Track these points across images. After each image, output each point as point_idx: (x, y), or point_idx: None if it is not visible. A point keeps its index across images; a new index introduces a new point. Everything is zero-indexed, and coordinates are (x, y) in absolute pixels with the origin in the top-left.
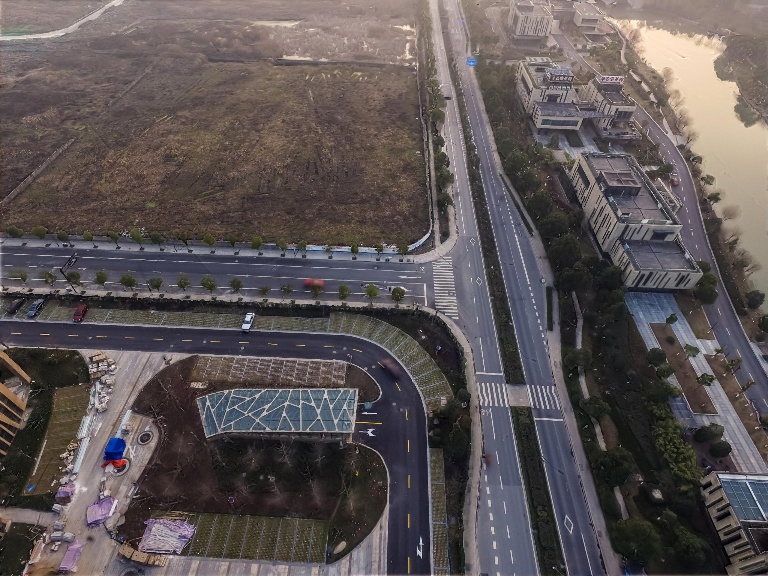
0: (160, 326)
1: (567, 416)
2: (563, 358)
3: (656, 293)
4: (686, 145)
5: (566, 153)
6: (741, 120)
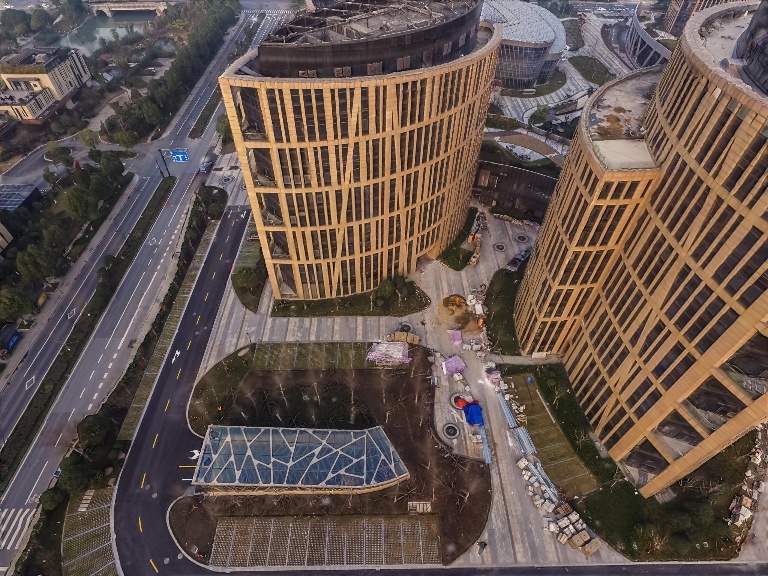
0: None
1: None
2: None
3: None
4: None
5: None
6: None
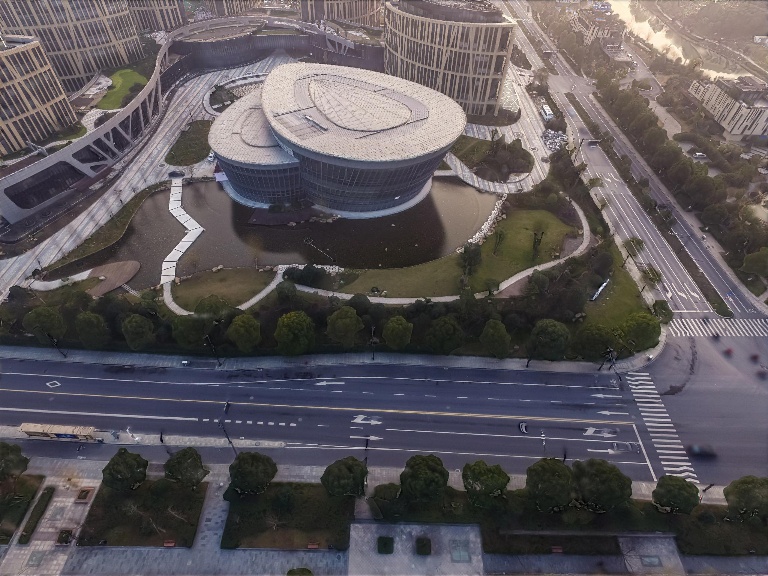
0: None
1: None
2: (533, 15)
3: (568, 8)
4: None
5: None
6: None
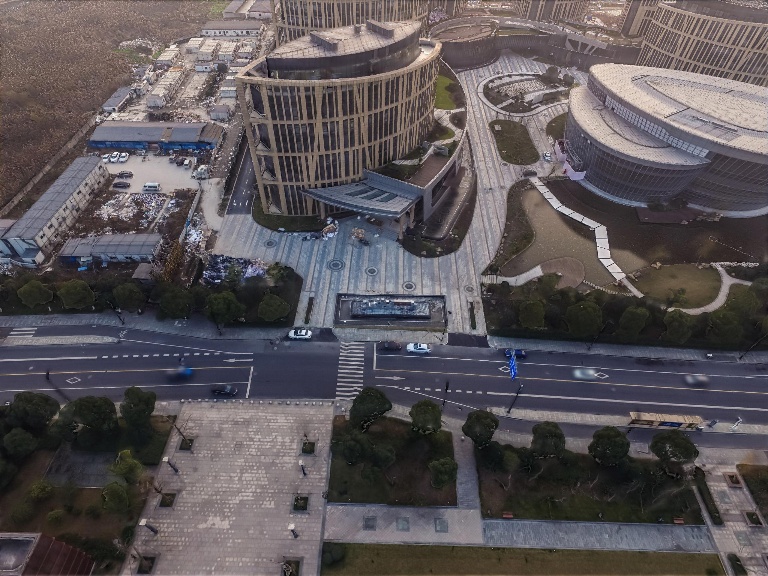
0: None
1: None
2: None
3: None
4: None
5: None
6: None
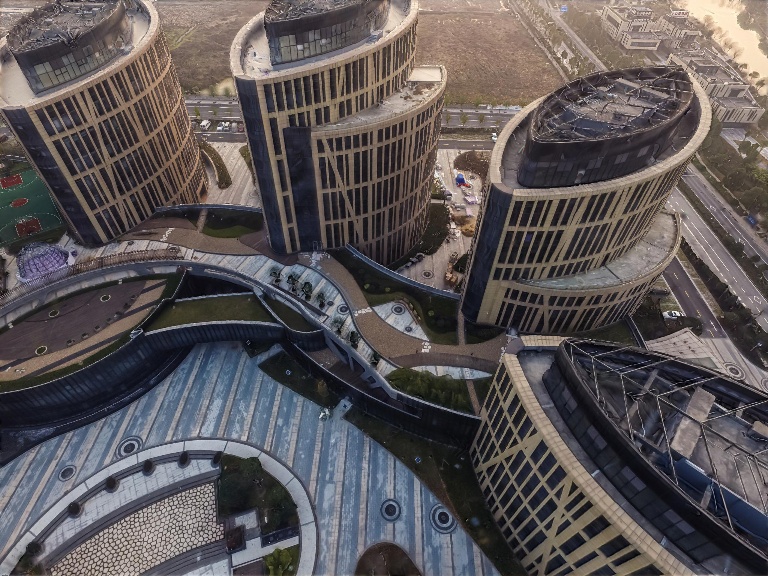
0: (442, 139)
1: (698, 174)
2: None
3: (733, 128)
4: (733, 60)
5: (653, 62)
6: (764, 54)
